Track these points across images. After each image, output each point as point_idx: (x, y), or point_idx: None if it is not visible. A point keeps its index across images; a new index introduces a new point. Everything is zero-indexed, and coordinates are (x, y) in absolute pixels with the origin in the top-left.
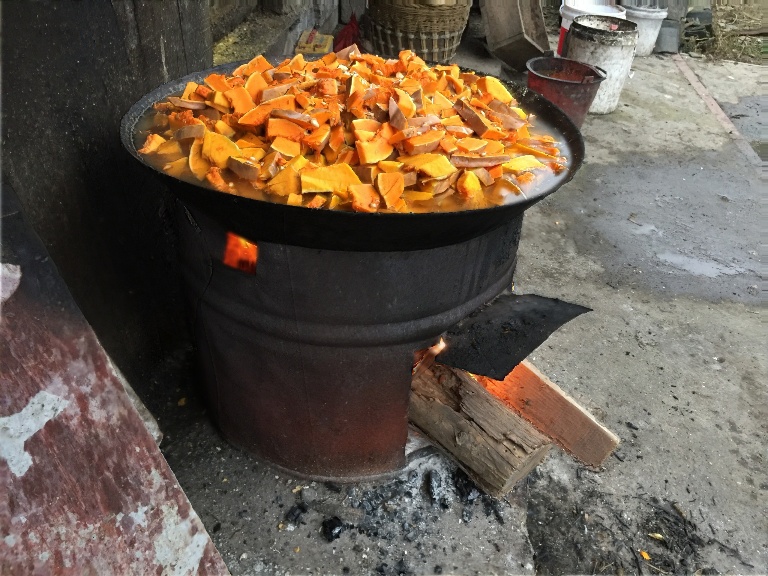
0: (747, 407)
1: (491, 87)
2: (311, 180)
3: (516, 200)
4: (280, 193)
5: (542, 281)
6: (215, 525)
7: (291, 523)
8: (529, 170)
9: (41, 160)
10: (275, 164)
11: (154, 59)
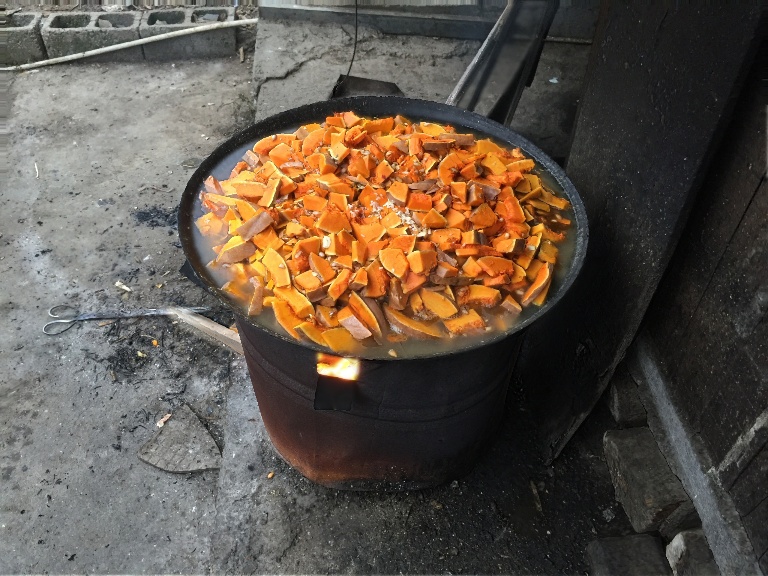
0: None
1: None
2: None
3: None
4: None
5: None
6: None
7: None
8: None
9: None
10: None
11: (750, 395)
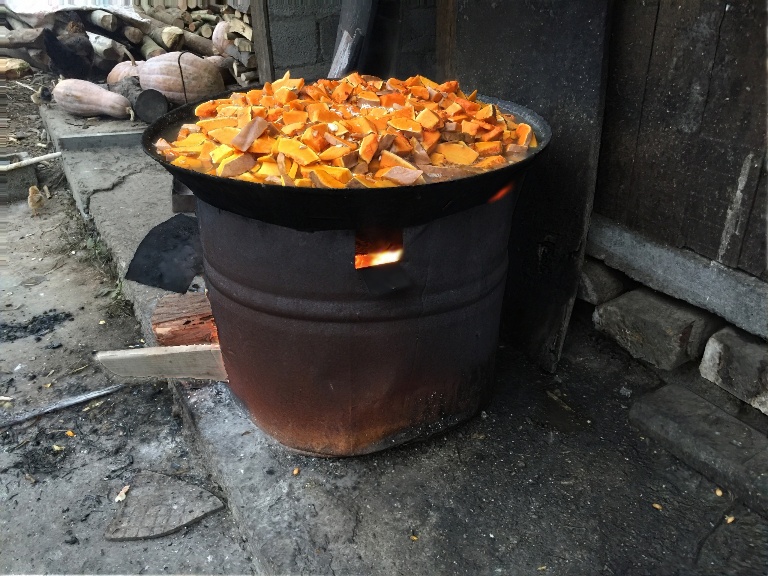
0: None
1: None
2: None
3: None
4: None
5: None
6: None
7: None
8: None
9: None
10: None
11: (722, 169)
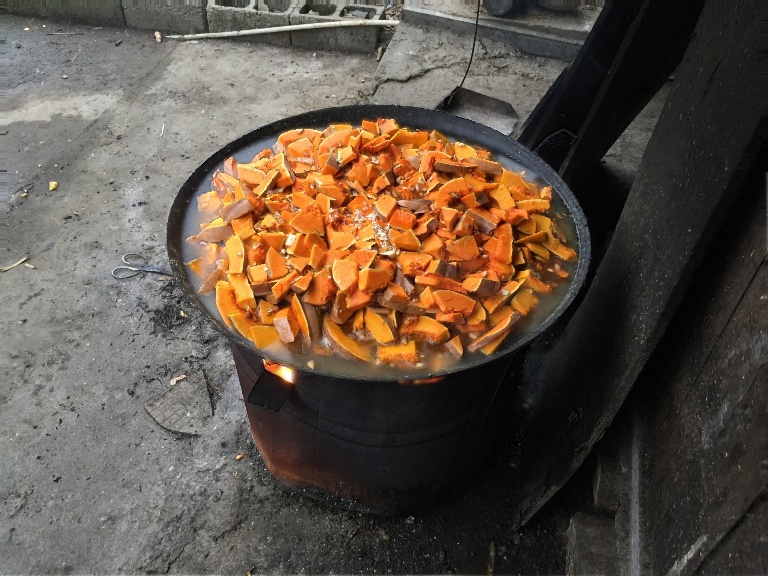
0: (1, 408)
1: None
2: None
3: None
4: None
5: None
6: None
7: None
8: None
9: None
10: None
11: None
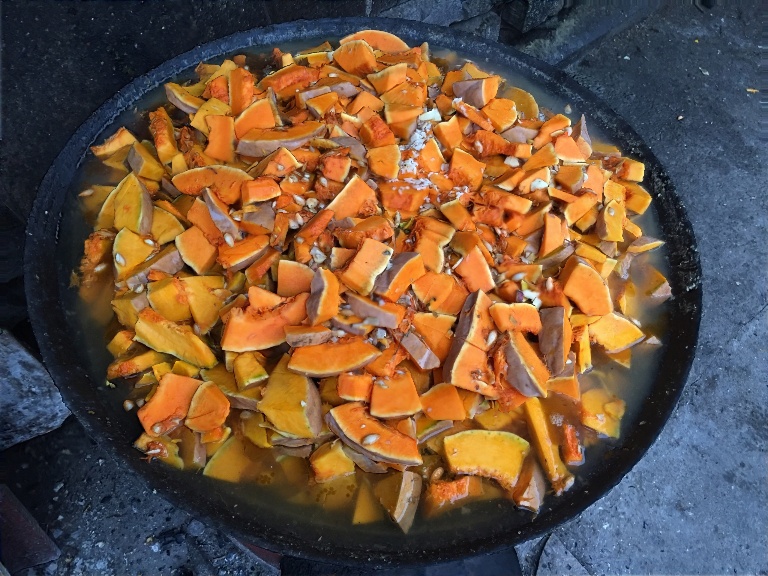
0: None
1: (579, 282)
2: (147, 331)
3: (391, 521)
4: (121, 319)
5: (735, 425)
6: (107, 495)
7: (160, 544)
8: (478, 474)
9: (50, 93)
10: (148, 273)
11: None
